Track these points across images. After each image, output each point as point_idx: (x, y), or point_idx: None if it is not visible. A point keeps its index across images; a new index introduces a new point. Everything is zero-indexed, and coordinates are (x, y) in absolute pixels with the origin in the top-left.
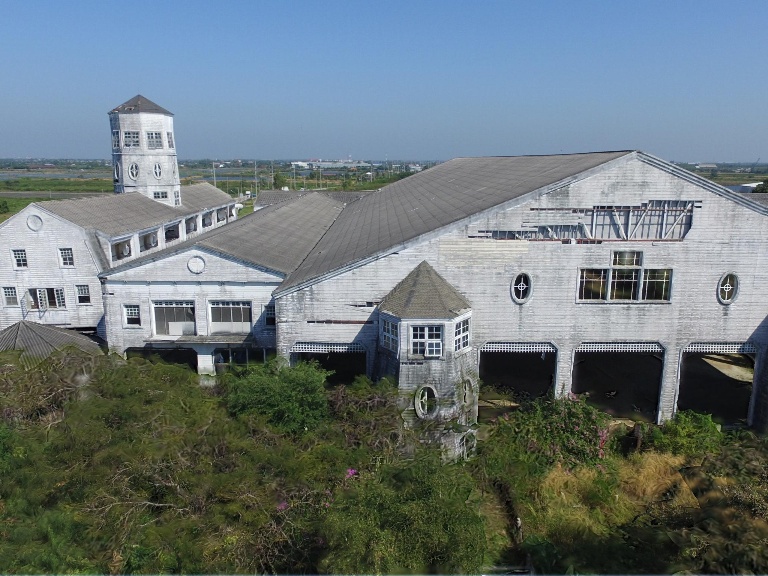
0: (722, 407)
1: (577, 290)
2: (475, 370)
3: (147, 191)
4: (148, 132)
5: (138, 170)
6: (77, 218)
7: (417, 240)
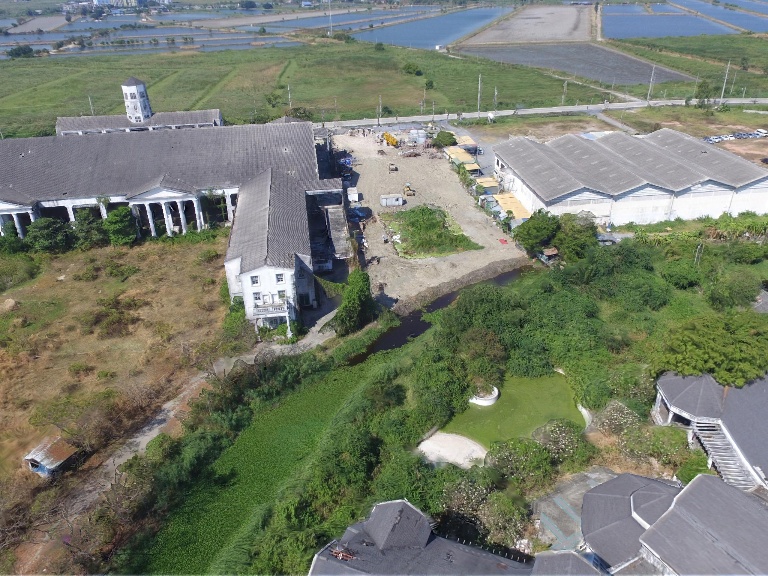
0: None
1: None
2: None
3: None
4: None
5: None
6: None
7: None
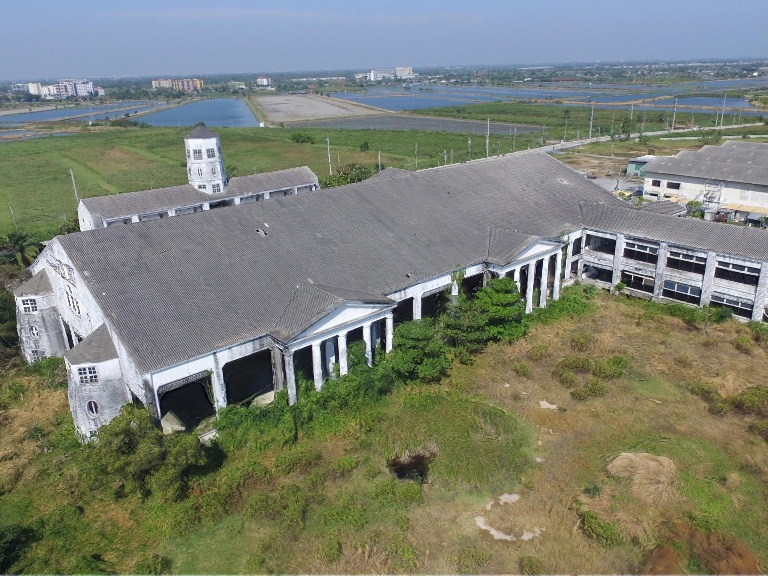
0: (187, 403)
1: (66, 300)
2: (43, 323)
3: (195, 184)
4: (194, 150)
5: (191, 172)
6: (98, 207)
7: (39, 258)
